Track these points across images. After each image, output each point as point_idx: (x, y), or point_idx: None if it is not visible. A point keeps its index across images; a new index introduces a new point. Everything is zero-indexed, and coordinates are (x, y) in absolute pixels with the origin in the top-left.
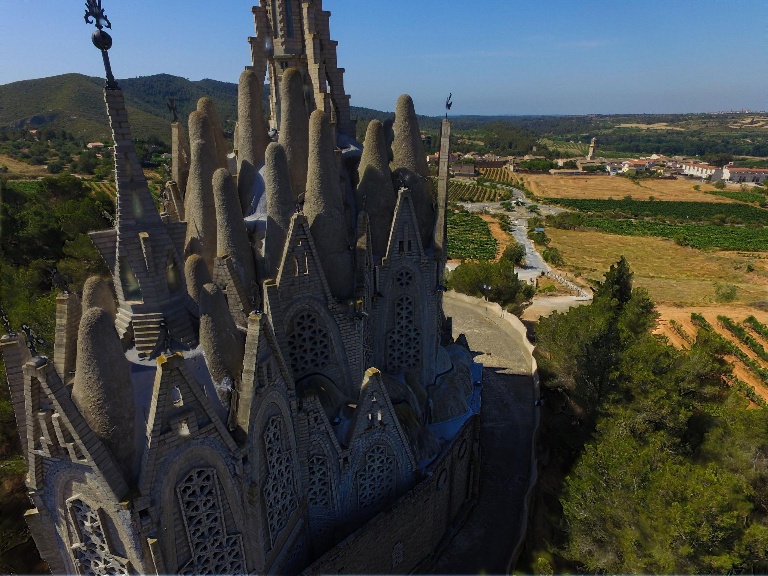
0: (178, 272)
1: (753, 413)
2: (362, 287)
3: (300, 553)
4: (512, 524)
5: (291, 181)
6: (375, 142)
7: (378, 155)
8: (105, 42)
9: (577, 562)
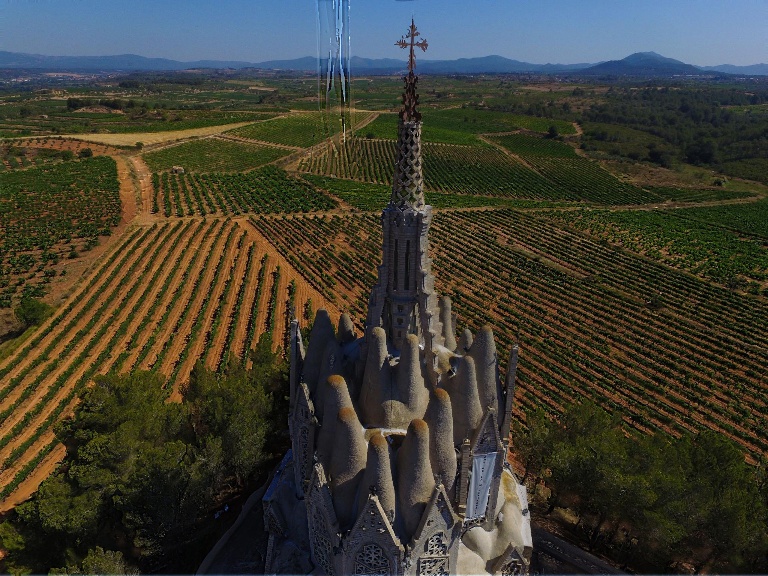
0: None
1: None
2: None
3: None
4: None
5: None
6: None
7: None
8: None
9: None
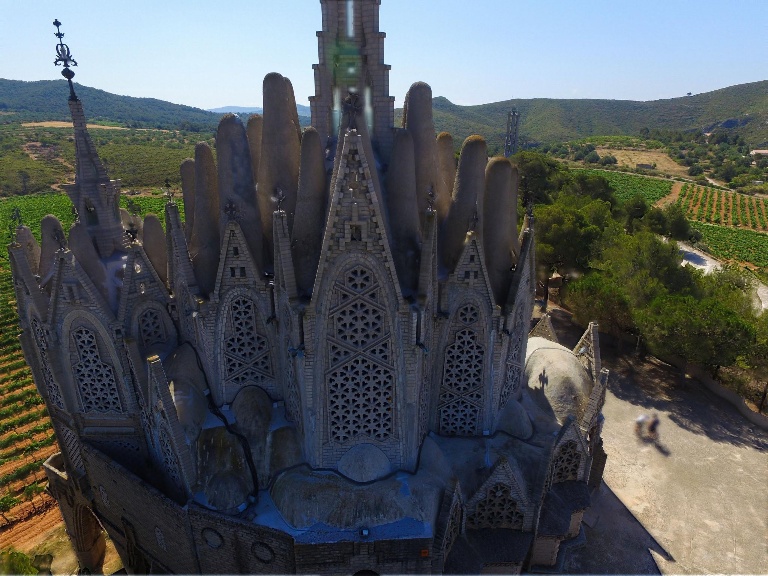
0: (98, 214)
1: None
2: (213, 292)
3: (134, 453)
4: None
5: (259, 181)
6: (300, 153)
7: (300, 168)
8: (66, 75)
9: None
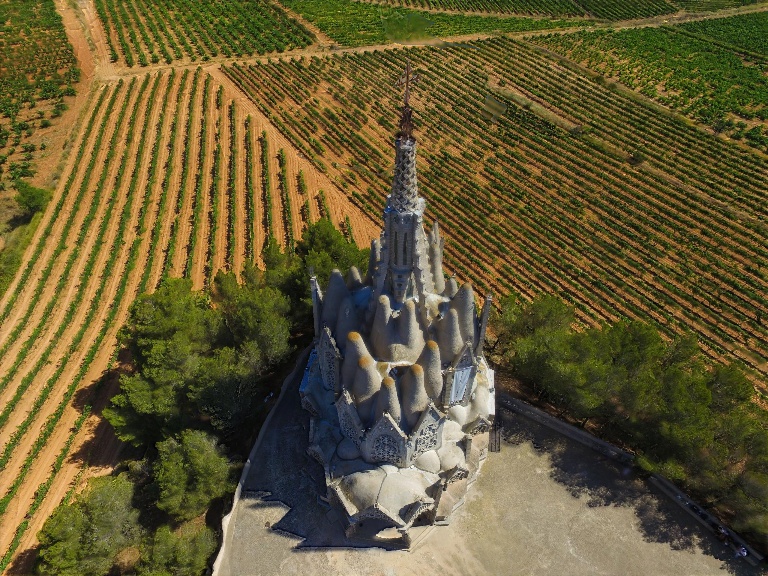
0: None
1: (185, 352)
2: None
3: None
4: (304, 366)
5: None
6: None
7: None
8: None
9: (276, 381)
